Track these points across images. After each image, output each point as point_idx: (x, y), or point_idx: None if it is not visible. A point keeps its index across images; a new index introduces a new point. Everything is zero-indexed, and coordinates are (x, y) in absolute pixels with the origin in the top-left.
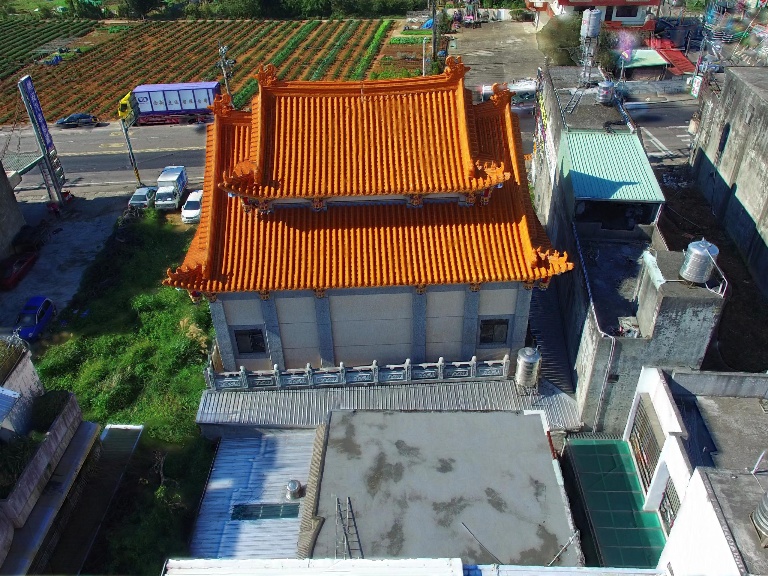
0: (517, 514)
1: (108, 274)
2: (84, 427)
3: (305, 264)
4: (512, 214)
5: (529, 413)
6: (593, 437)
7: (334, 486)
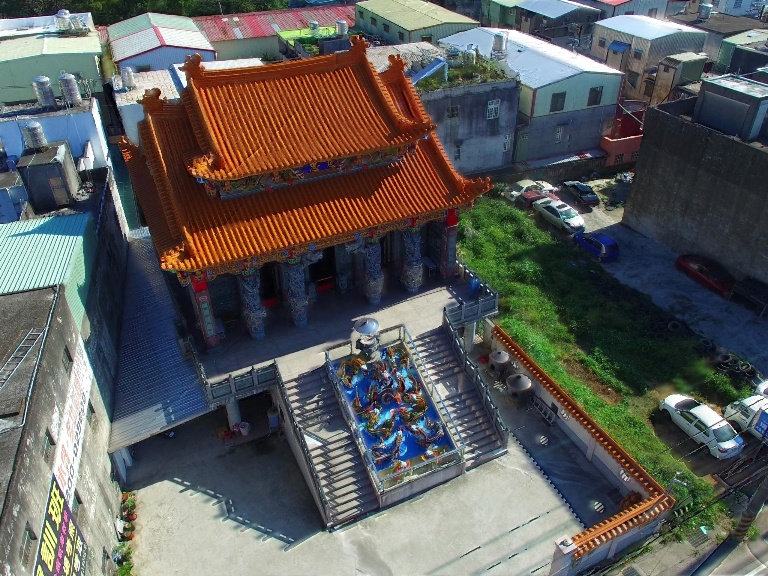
0: None
1: None
2: None
3: None
4: None
5: None
6: None
7: None
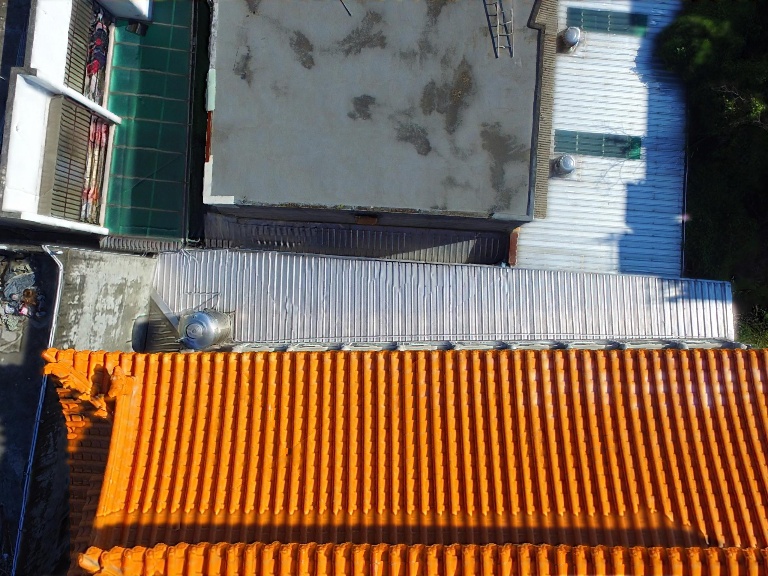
0: (280, 28)
1: None
2: None
3: (632, 415)
4: (128, 539)
5: (228, 198)
6: (148, 245)
7: (519, 77)
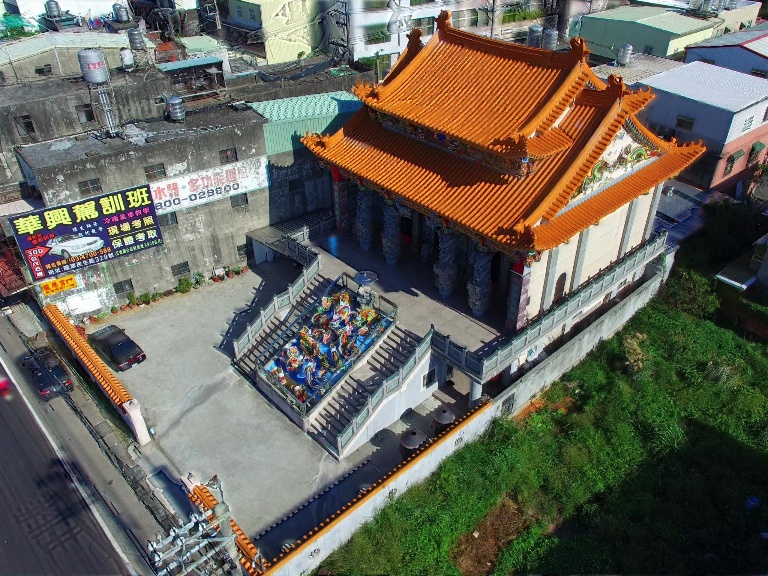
0: None
1: (703, 568)
2: (766, 241)
3: None
4: None
5: None
6: None
7: None
